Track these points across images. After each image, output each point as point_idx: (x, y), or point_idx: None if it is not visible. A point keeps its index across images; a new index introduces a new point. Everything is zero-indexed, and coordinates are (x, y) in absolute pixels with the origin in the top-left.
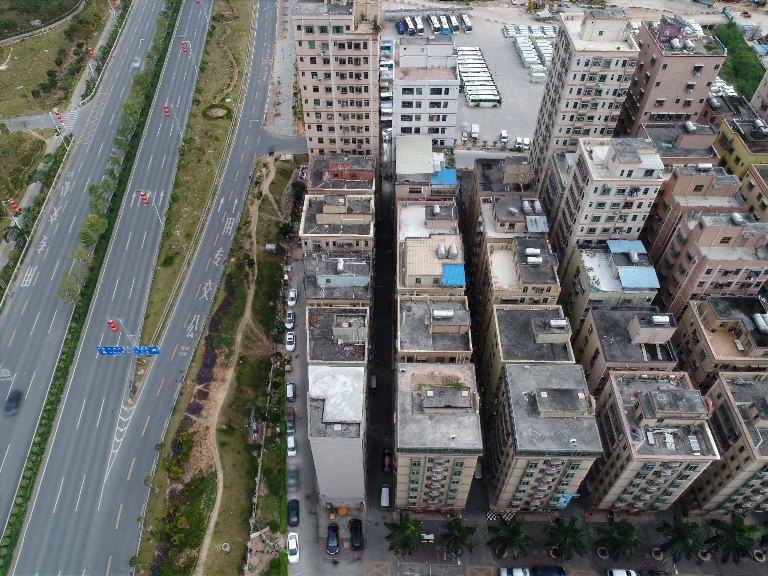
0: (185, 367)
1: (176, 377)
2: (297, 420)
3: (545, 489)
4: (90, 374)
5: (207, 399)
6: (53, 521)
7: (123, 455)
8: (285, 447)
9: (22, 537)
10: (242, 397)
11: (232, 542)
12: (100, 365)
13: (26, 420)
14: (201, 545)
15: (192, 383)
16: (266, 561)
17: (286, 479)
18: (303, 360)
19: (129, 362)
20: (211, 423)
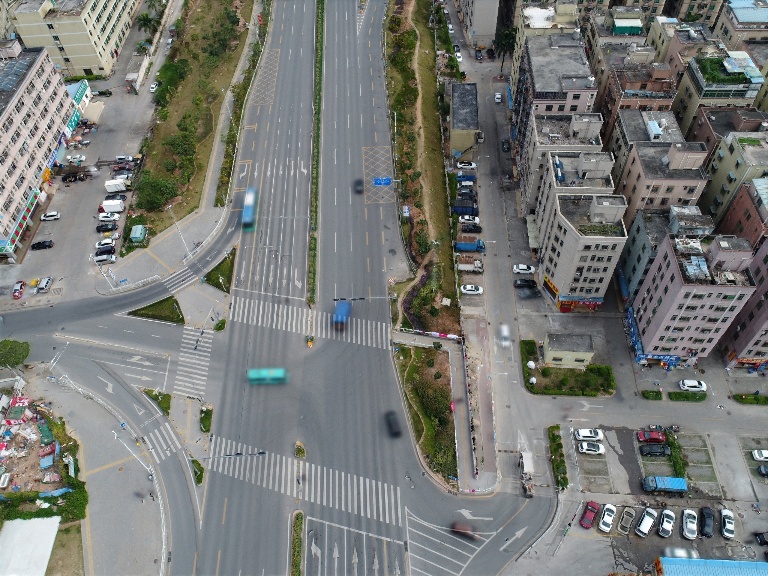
0: (387, 2)
1: (383, 5)
2: (451, 23)
3: (591, 8)
4: (335, 4)
5: (403, 9)
6: (337, 45)
7: (364, 28)
8: (447, 30)
9: (324, 49)
10: (421, 11)
11: (428, 52)
12: (339, 2)
13: (308, 18)
14: (415, 49)
15: (393, 5)
16: (446, 62)
17: (450, 39)
18: (450, 5)
19: (355, 0)
20: (408, 16)
